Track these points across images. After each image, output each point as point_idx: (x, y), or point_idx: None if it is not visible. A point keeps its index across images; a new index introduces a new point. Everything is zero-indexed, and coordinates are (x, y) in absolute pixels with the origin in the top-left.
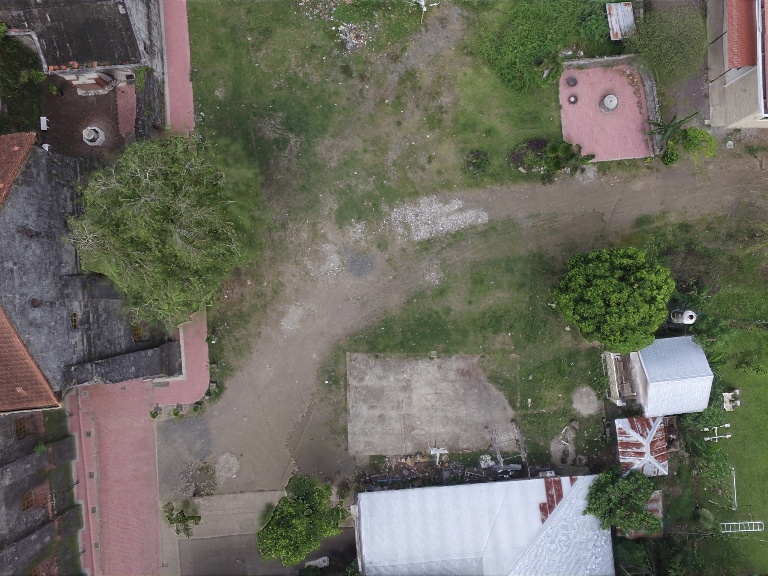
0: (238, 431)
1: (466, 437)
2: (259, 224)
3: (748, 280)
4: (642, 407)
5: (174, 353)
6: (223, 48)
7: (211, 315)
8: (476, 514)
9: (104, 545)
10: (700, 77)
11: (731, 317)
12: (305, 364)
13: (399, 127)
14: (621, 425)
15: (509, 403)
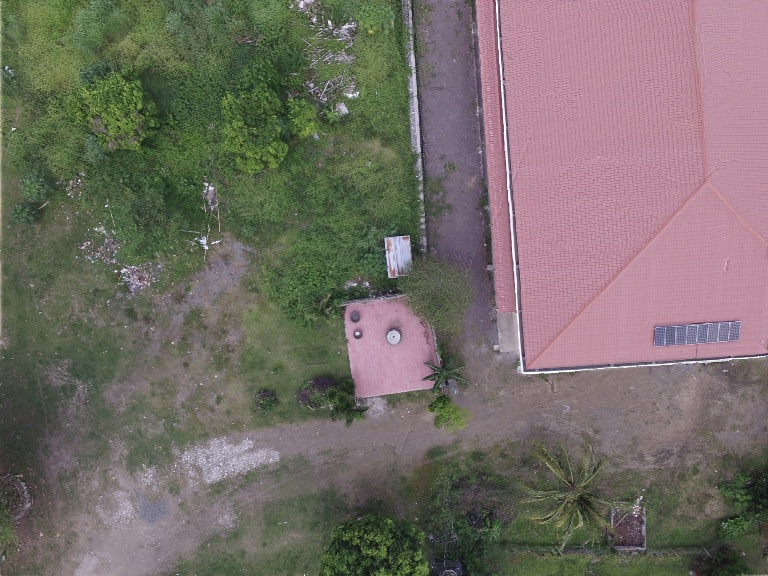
0: None
1: None
2: (49, 474)
3: (544, 506)
4: None
5: None
6: (6, 297)
7: (5, 569)
8: None
9: None
10: (488, 302)
11: (531, 542)
12: None
13: (186, 368)
14: None
15: None
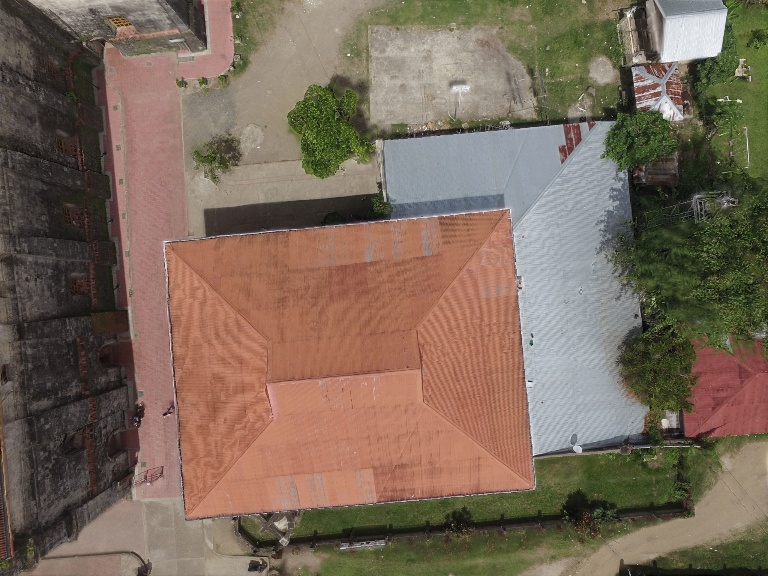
0: (262, 103)
1: (485, 105)
2: None
3: None
4: (658, 54)
5: (199, 20)
6: None
7: None
8: (497, 156)
9: (131, 216)
10: None
11: None
12: (327, 38)
13: None
14: (637, 71)
15: (527, 72)
